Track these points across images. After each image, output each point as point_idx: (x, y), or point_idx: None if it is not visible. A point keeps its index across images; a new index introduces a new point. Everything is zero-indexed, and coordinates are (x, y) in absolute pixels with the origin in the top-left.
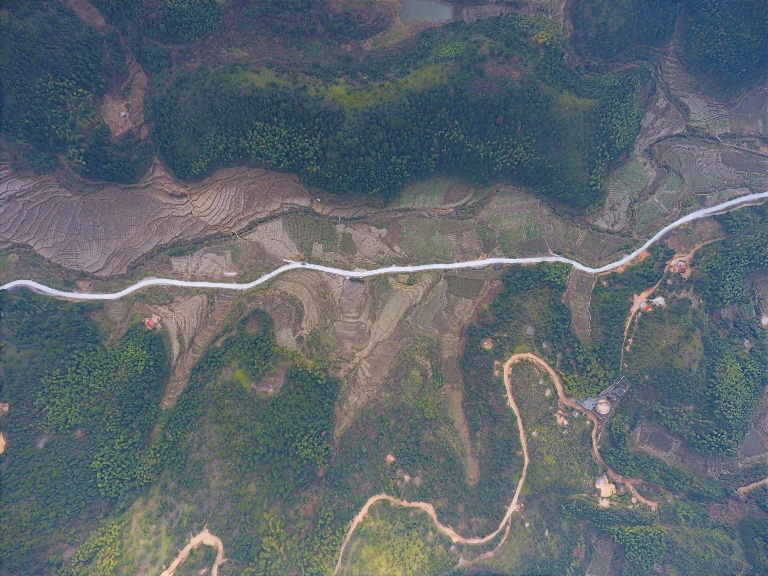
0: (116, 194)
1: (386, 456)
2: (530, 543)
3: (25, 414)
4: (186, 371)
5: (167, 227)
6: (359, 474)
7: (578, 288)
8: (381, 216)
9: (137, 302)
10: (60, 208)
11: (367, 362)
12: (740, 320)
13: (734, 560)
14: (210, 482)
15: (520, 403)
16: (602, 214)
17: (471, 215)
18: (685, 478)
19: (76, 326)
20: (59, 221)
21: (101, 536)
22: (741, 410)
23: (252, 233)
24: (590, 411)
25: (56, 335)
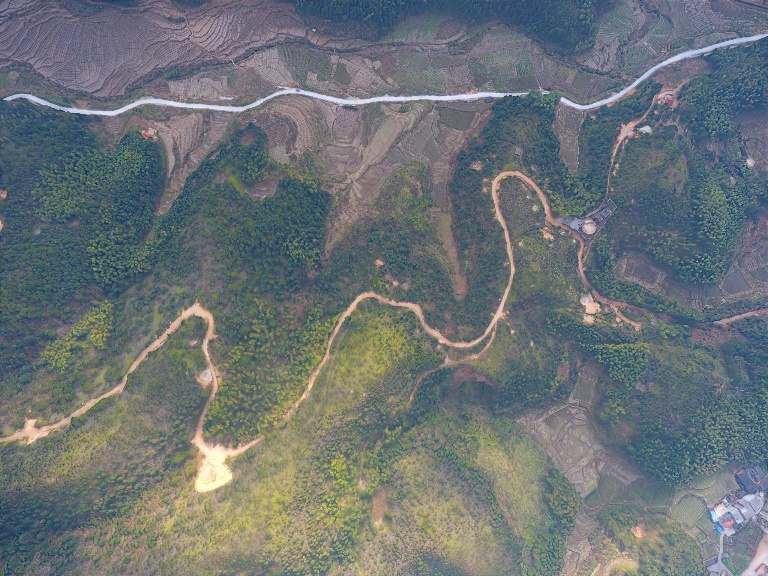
0: (115, 17)
1: (375, 260)
2: (515, 348)
3: (23, 201)
4: (181, 184)
5: (165, 51)
6: (348, 277)
7: (567, 124)
8: (375, 49)
9: (134, 116)
10: (60, 29)
11: (359, 184)
12: (725, 156)
13: (715, 375)
14: (202, 264)
15: (507, 215)
16: (592, 55)
17: (463, 51)
18: (669, 303)
19: (74, 129)
20: (59, 41)
21: (95, 315)
22: (725, 236)
23: (248, 61)
24: (576, 232)
25: (54, 134)
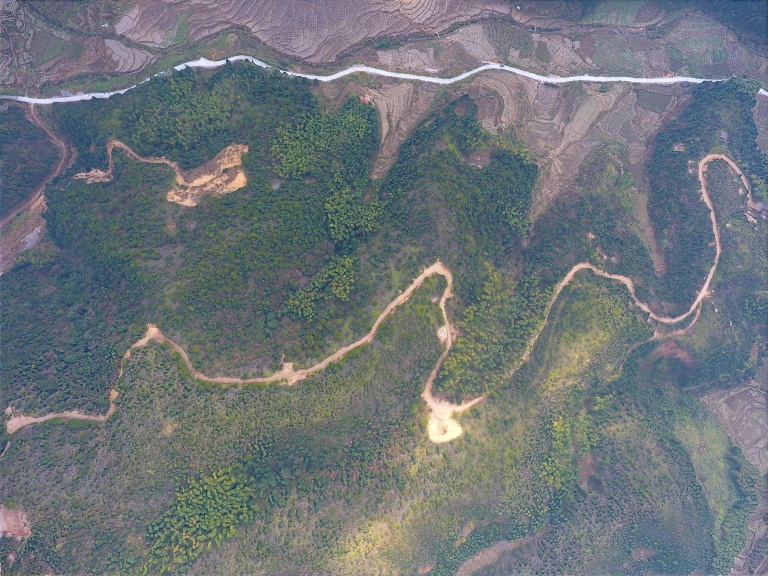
0: None
1: (588, 233)
2: (719, 327)
3: (263, 157)
4: (392, 151)
5: (375, 21)
6: (561, 248)
7: (760, 112)
8: (575, 29)
9: (351, 82)
10: None
11: (559, 160)
12: None
13: None
14: (438, 226)
15: (716, 196)
16: None
17: (661, 35)
18: None
19: (302, 91)
20: (276, 7)
21: (333, 269)
22: None
23: (453, 34)
24: None
25: (286, 95)
